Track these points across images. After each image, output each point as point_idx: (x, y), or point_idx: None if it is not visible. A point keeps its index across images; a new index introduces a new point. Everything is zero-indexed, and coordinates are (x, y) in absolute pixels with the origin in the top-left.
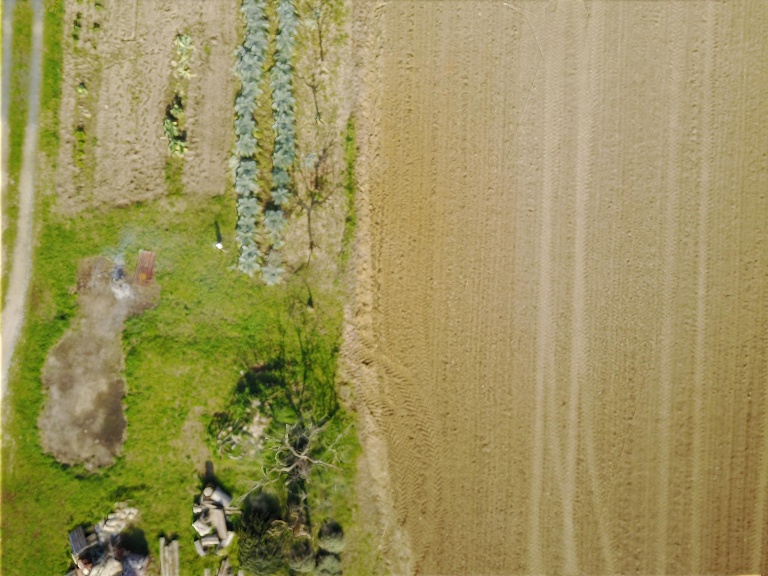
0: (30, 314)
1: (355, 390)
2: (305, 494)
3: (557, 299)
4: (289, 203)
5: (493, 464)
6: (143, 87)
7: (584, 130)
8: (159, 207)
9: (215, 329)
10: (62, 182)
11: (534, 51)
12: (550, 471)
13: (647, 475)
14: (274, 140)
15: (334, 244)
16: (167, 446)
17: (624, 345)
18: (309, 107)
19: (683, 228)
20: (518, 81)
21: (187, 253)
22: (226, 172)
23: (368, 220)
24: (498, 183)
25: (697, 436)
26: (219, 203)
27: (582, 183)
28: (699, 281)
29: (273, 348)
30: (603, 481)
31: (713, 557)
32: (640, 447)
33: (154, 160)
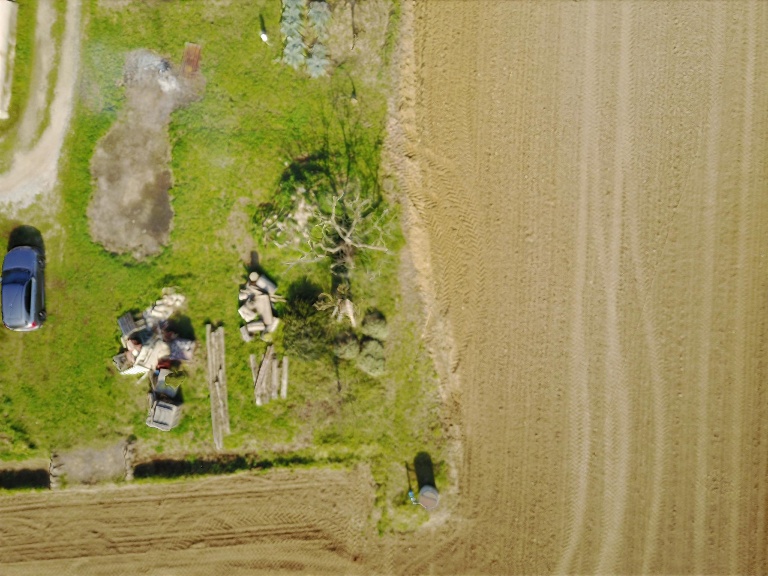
0: (79, 106)
1: (398, 183)
2: (349, 284)
3: (602, 88)
4: None
5: (536, 254)
6: None
7: None
8: (204, 0)
9: (260, 121)
10: None
11: None
12: (593, 260)
13: (691, 262)
14: None
15: (378, 38)
16: (213, 236)
17: (669, 133)
18: None
19: (731, 16)
20: None
21: (232, 46)
22: None
23: (411, 16)
24: None
25: (743, 224)
26: None
27: None
28: (747, 67)
29: (317, 140)
30: (647, 269)
31: (757, 344)
32: (685, 235)
33: None
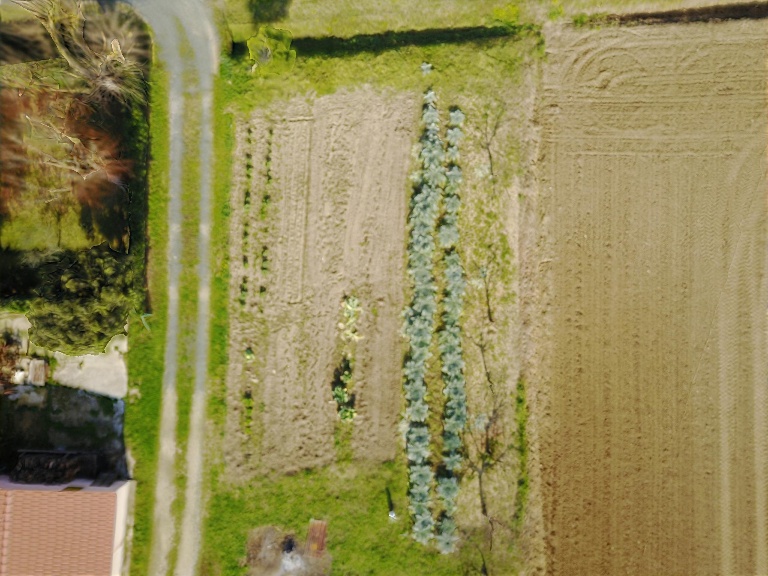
0: None
1: None
2: None
3: (740, 567)
4: (461, 467)
5: None
6: (310, 350)
7: (761, 391)
8: (329, 474)
9: None
10: (230, 450)
11: (707, 311)
12: None
13: None
14: (444, 403)
15: (507, 508)
16: None
17: None
18: (477, 367)
19: None
20: (692, 342)
21: (358, 521)
22: (396, 436)
23: (539, 480)
24: (673, 444)
25: None
26: (389, 468)
27: (760, 444)
28: None
29: None
30: None
31: None
32: None
33: (323, 425)
